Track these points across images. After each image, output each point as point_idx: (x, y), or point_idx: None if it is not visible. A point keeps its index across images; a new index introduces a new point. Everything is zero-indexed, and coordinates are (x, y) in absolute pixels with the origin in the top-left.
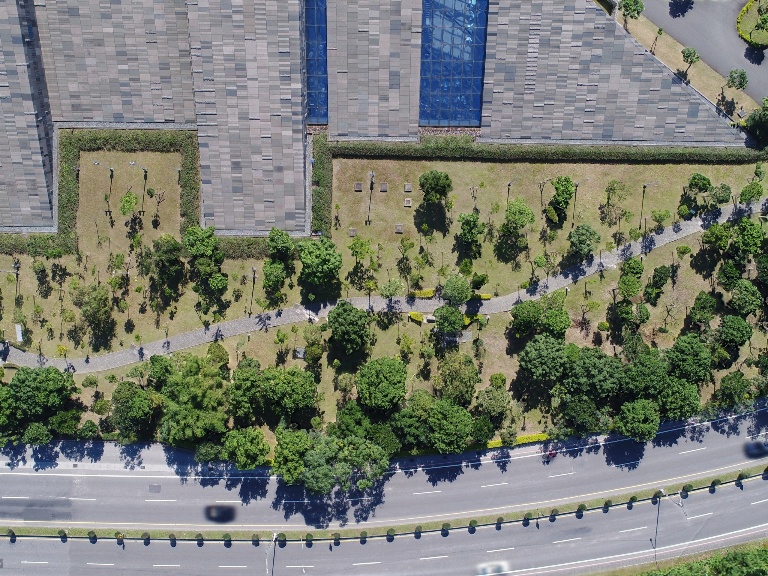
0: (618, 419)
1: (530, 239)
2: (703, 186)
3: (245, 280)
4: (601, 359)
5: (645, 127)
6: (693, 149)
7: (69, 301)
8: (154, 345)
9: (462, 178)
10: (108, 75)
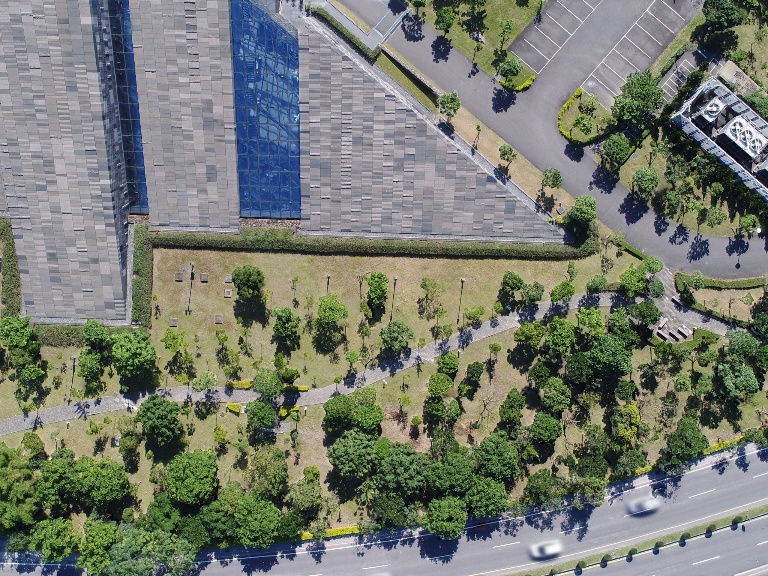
0: (425, 516)
1: (349, 331)
2: (514, 285)
3: (65, 368)
4: (410, 456)
5: (463, 222)
6: (510, 245)
7: None
8: None
9: (282, 270)
10: None
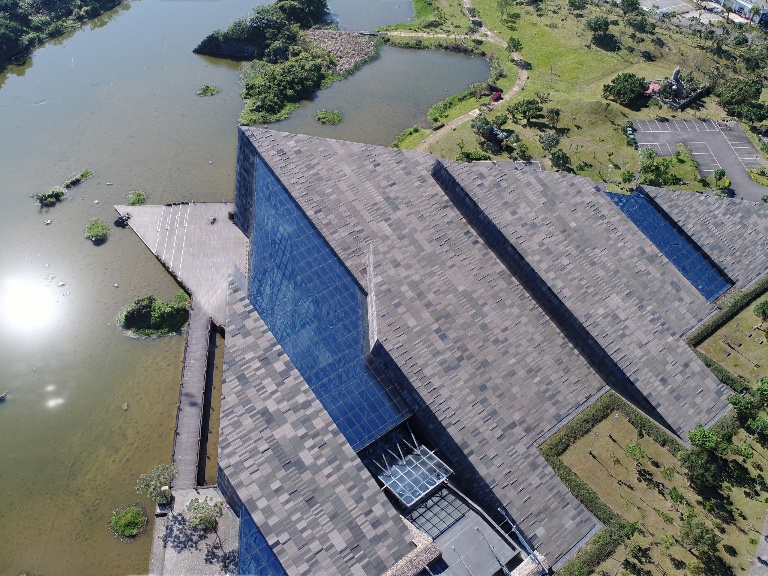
0: None
1: None
2: None
3: None
4: None
5: None
6: None
7: (671, 570)
8: (762, 548)
9: None
10: (532, 392)
